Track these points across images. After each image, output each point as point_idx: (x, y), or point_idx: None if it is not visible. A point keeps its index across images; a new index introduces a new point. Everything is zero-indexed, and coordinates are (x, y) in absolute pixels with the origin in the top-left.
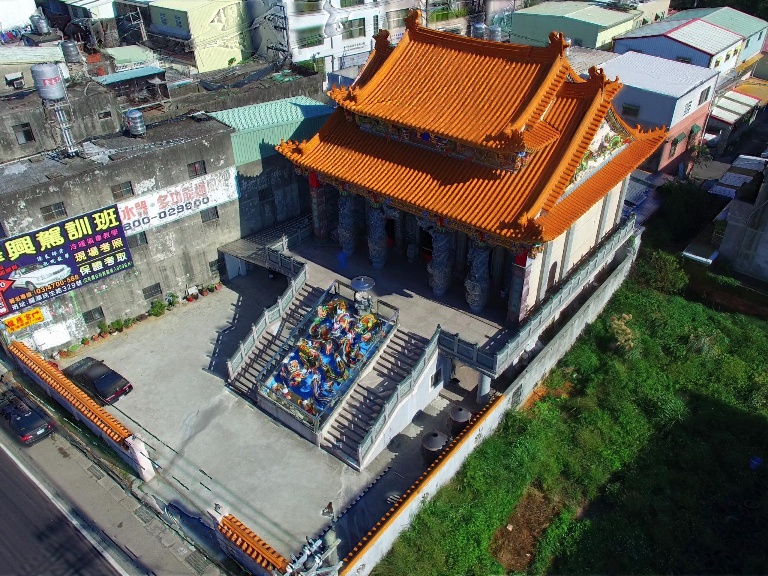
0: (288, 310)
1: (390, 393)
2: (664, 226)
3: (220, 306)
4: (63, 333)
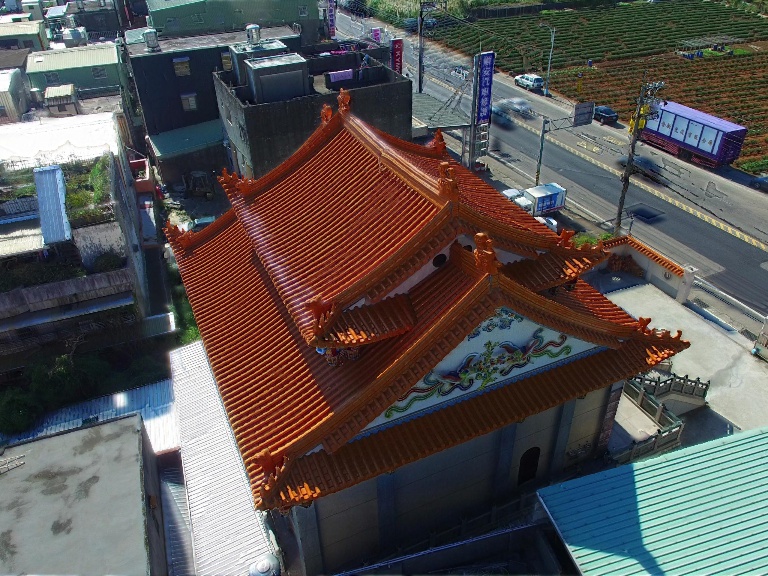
0: None
1: None
2: (120, 374)
3: None
4: None
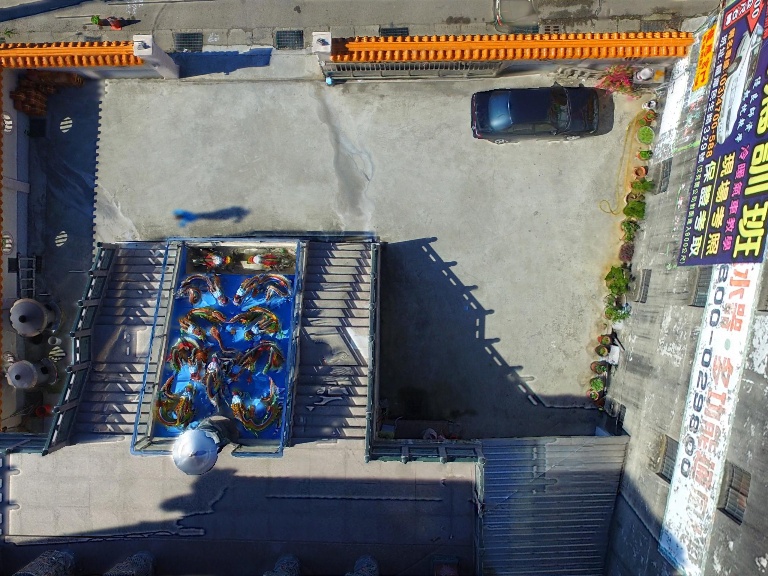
0: (367, 382)
1: (111, 338)
2: None
3: (545, 361)
4: (670, 123)
